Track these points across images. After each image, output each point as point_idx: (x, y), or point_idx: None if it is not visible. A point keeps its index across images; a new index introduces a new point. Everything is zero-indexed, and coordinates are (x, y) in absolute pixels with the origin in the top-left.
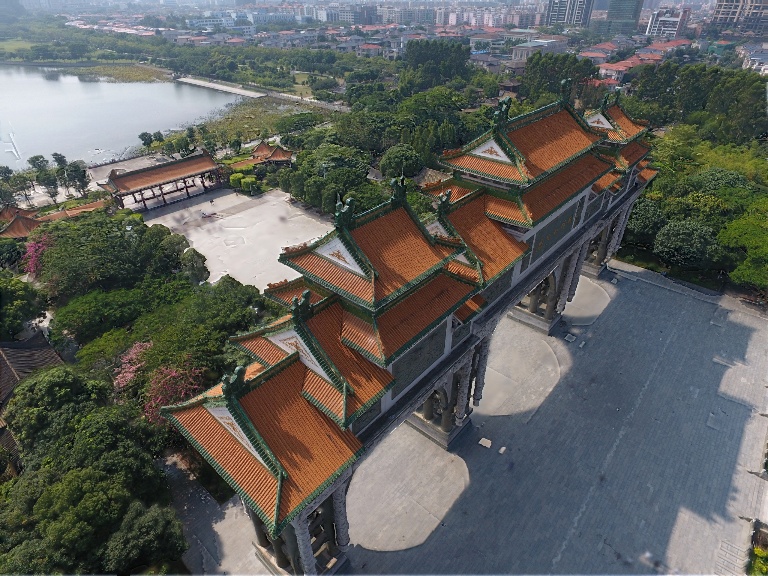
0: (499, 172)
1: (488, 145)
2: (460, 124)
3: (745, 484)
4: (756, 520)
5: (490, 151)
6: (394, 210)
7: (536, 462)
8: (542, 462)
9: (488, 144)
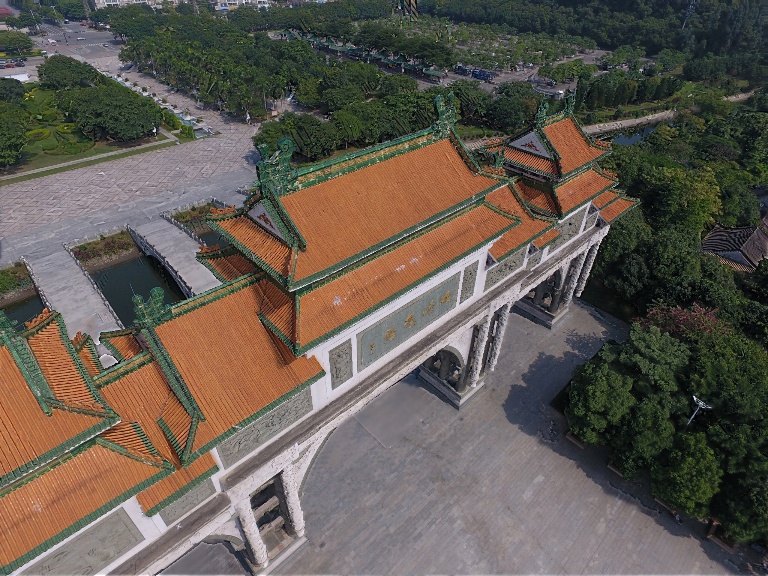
0: None
1: None
2: None
3: None
4: None
5: None
6: None
7: None
8: None
9: None
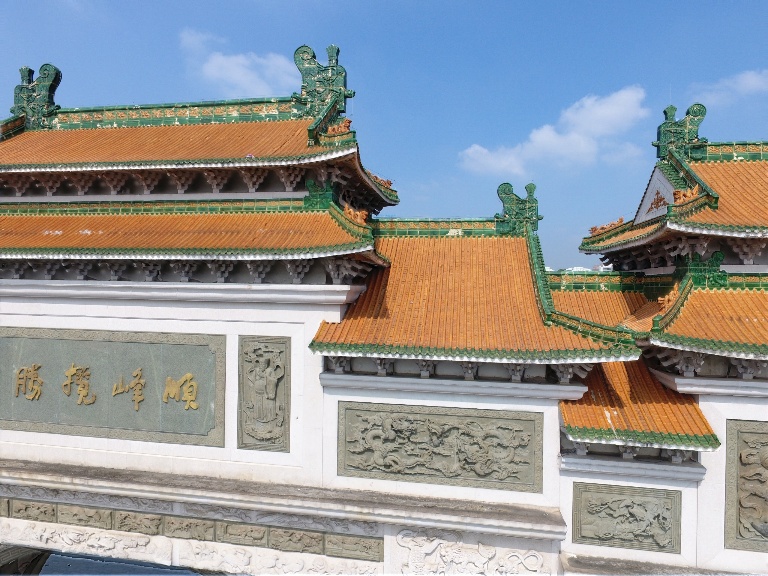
0: None
1: None
2: None
3: None
4: None
5: None
6: (697, 164)
7: None
8: None
9: None
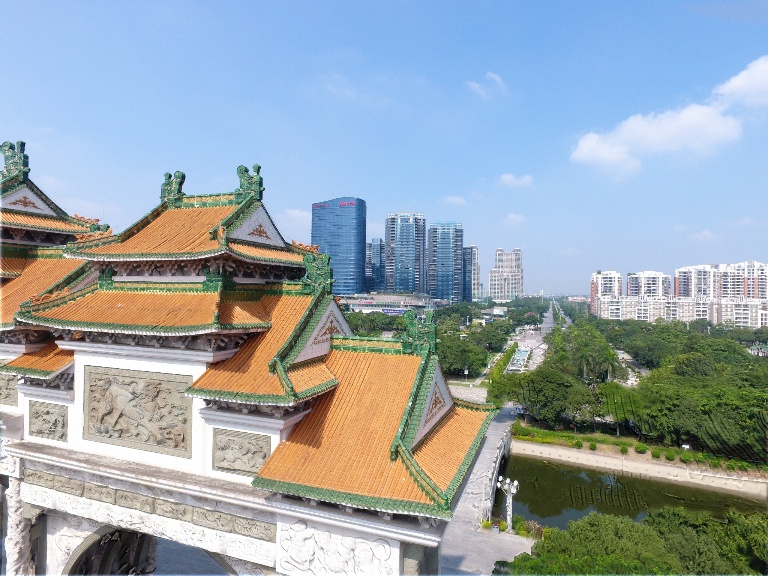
0: (55, 225)
1: (19, 194)
2: None
3: None
4: None
5: (24, 202)
6: None
7: (181, 574)
8: (181, 570)
9: (19, 193)
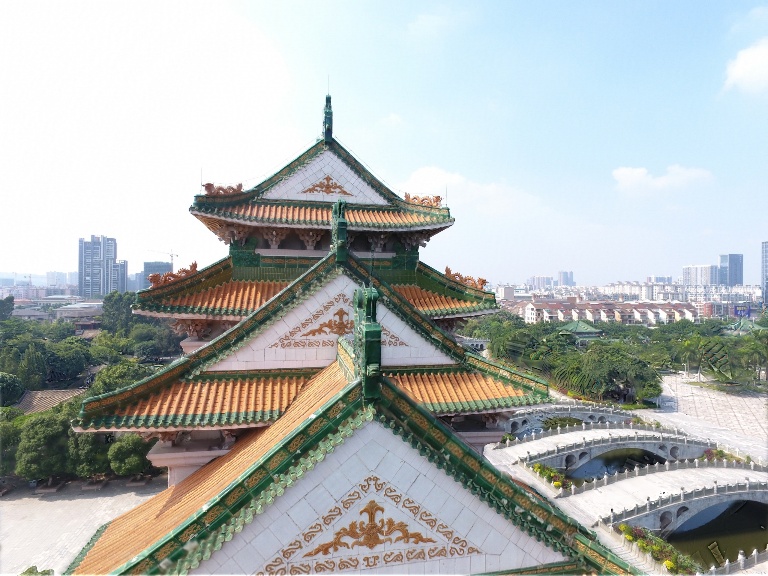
0: None
1: None
2: (49, 353)
3: (564, 507)
4: (601, 518)
5: None
6: None
7: None
8: None
9: None
